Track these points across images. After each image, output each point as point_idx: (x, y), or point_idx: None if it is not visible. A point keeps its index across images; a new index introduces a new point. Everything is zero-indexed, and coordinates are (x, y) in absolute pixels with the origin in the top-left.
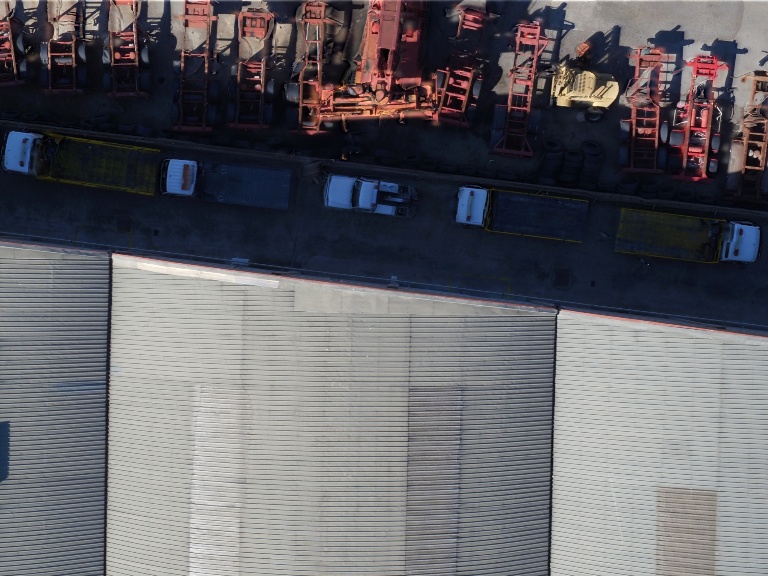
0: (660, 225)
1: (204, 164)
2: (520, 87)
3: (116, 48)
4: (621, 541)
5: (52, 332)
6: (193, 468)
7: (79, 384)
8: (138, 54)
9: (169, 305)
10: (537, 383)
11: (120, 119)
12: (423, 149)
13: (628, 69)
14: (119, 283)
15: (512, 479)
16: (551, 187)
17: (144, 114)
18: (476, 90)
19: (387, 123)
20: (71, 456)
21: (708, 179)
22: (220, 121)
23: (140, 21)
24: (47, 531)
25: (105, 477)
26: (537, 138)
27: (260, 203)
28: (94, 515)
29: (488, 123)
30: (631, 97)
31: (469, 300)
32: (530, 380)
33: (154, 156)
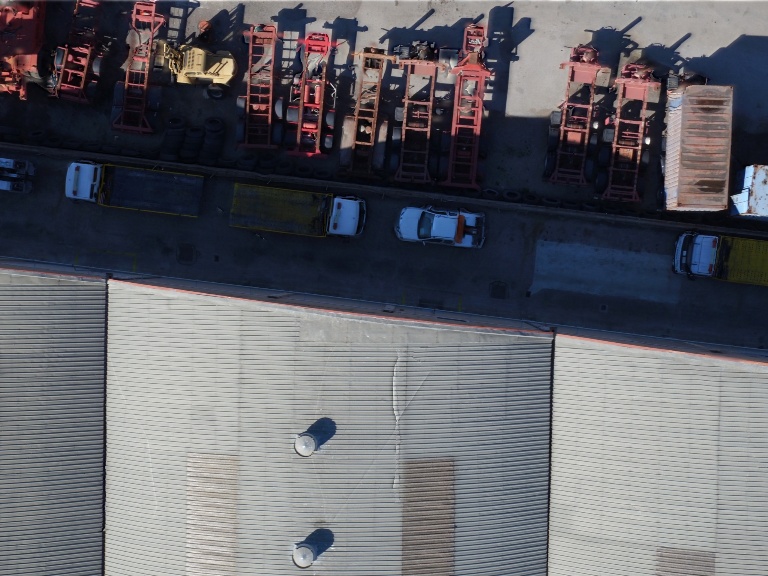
0: (273, 200)
1: None
2: (137, 64)
3: None
4: (156, 506)
5: None
6: None
7: None
8: None
9: None
10: (84, 352)
11: None
12: (49, 126)
13: (244, 46)
14: None
15: (58, 446)
16: (169, 163)
17: None
18: (96, 67)
19: (5, 99)
20: None
21: (322, 155)
22: None
23: None
24: None
25: None
26: (157, 114)
27: None
28: None
29: (110, 100)
30: (254, 74)
31: (14, 270)
32: (75, 349)
33: None
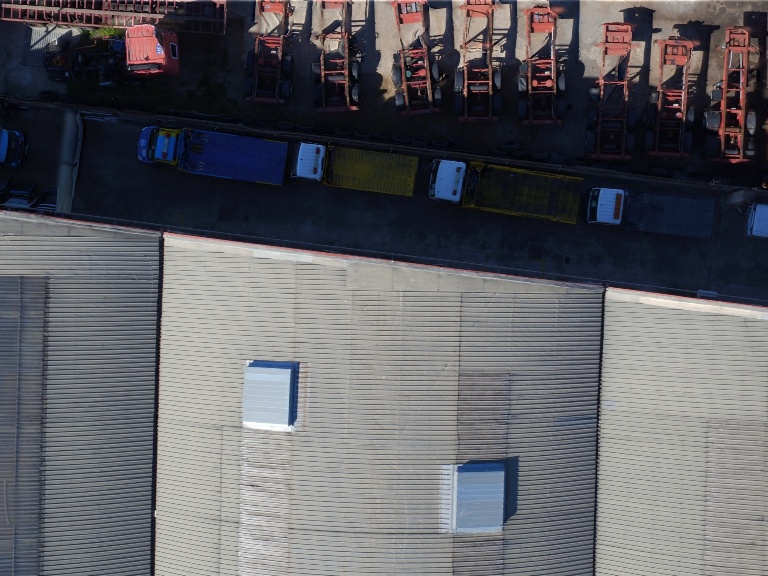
0: None
1: (629, 193)
2: None
3: (533, 76)
4: None
5: (556, 366)
6: (706, 504)
7: (577, 418)
8: (556, 82)
9: (687, 341)
10: None
11: (529, 146)
12: None
13: None
14: (614, 317)
15: None
16: None
17: (552, 141)
18: None
19: None
20: (569, 490)
21: None
22: (639, 149)
23: (550, 48)
24: (548, 566)
25: (595, 511)
26: None
27: (682, 232)
28: (585, 549)
29: None
30: None
31: None
32: None
33: (578, 184)
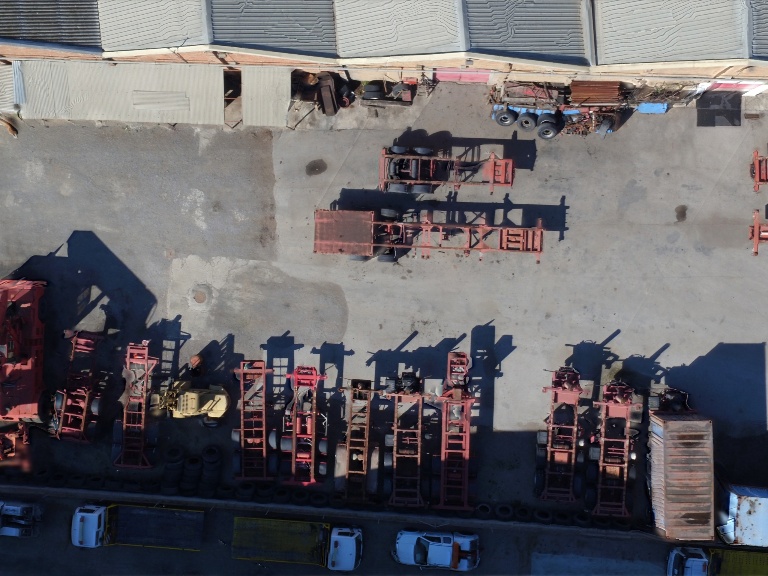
0: (272, 531)
1: None
2: (133, 405)
3: None
4: None
5: None
6: None
7: None
8: None
9: None
10: None
11: None
12: (53, 463)
13: (236, 381)
14: None
15: None
16: (169, 498)
17: None
18: (94, 408)
19: None
20: None
21: (317, 483)
22: None
23: None
24: None
25: None
26: (155, 451)
27: None
28: None
29: (110, 437)
30: (247, 402)
31: None
32: None
33: None
